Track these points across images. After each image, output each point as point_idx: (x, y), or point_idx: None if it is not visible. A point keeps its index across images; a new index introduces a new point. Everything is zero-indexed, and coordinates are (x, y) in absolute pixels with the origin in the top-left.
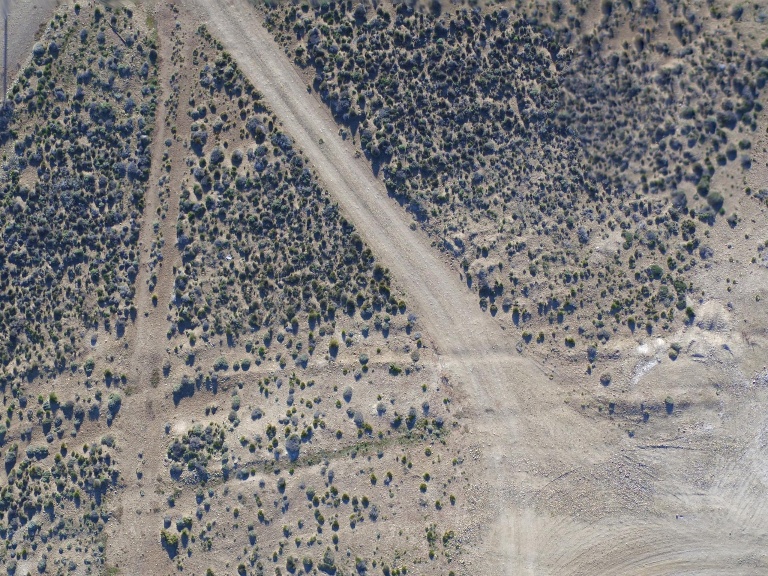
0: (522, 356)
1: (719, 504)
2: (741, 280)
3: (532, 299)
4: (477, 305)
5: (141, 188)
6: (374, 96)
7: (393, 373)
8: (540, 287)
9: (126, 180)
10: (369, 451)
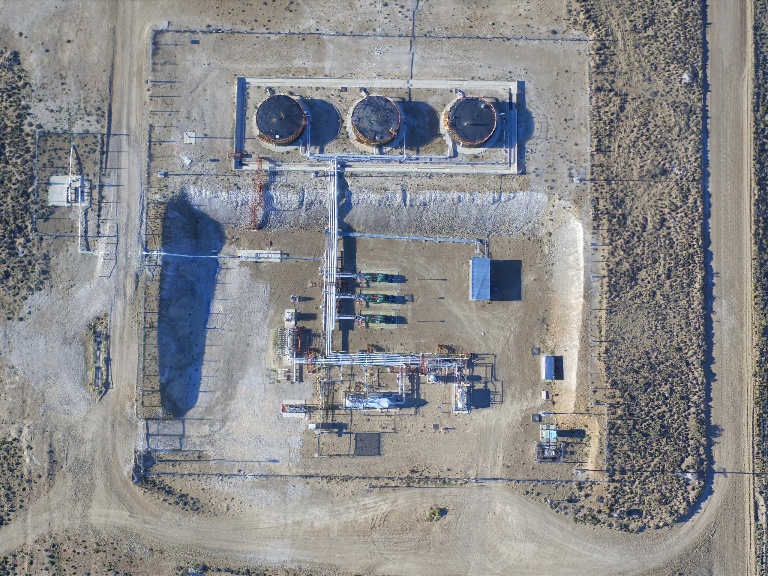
0: (29, 509)
1: (90, 435)
2: (3, 418)
3: (5, 504)
4: (7, 527)
5: None
6: None
7: (32, 564)
8: (0, 501)
9: None
10: (63, 575)
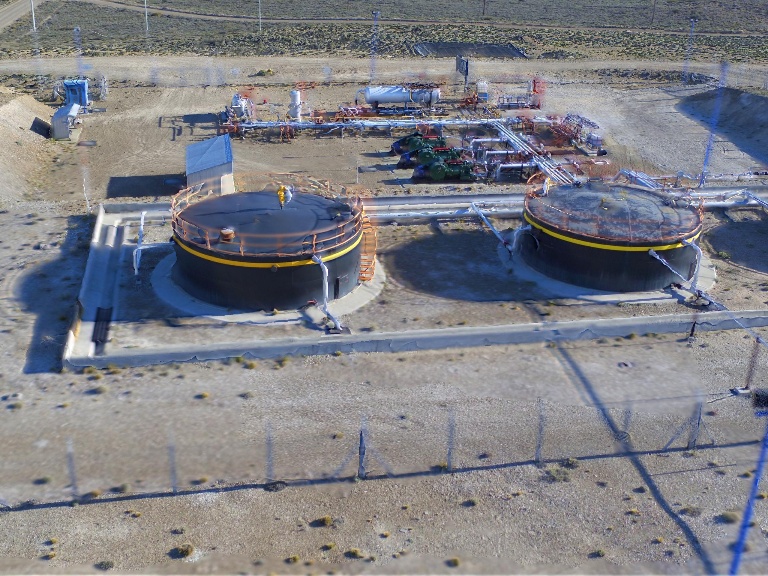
0: None
1: None
2: None
3: None
4: None
5: (767, 45)
6: None
7: None
8: None
9: (766, 44)
10: None
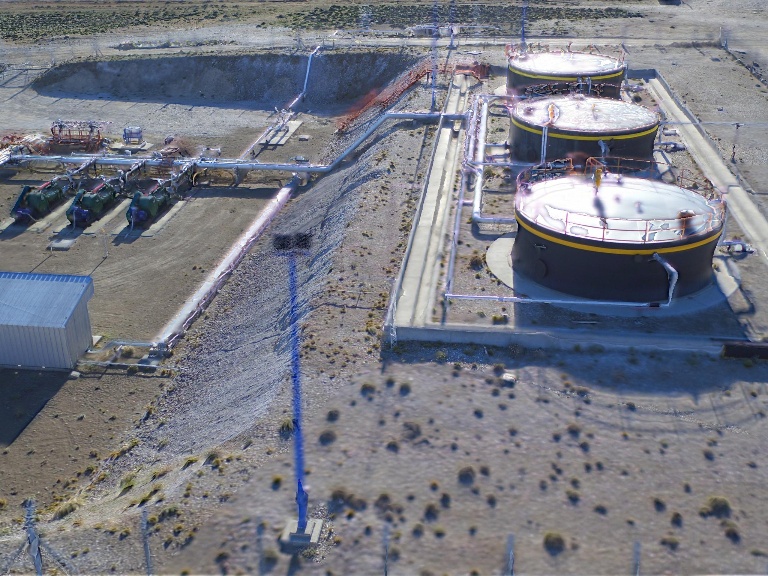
0: None
1: None
2: None
3: None
4: None
5: None
6: (8, 22)
7: None
8: None
9: None
10: None
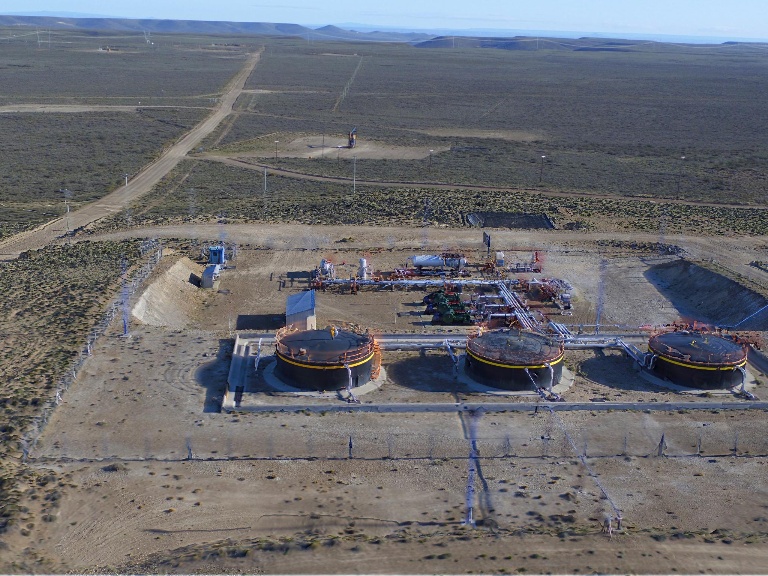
0: None
1: None
2: None
3: None
4: None
5: (760, 218)
6: None
7: None
8: None
9: None
10: None
